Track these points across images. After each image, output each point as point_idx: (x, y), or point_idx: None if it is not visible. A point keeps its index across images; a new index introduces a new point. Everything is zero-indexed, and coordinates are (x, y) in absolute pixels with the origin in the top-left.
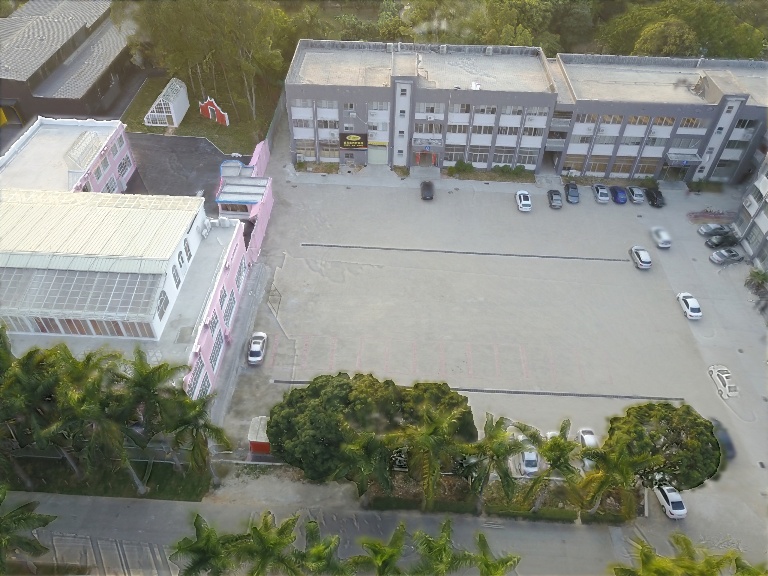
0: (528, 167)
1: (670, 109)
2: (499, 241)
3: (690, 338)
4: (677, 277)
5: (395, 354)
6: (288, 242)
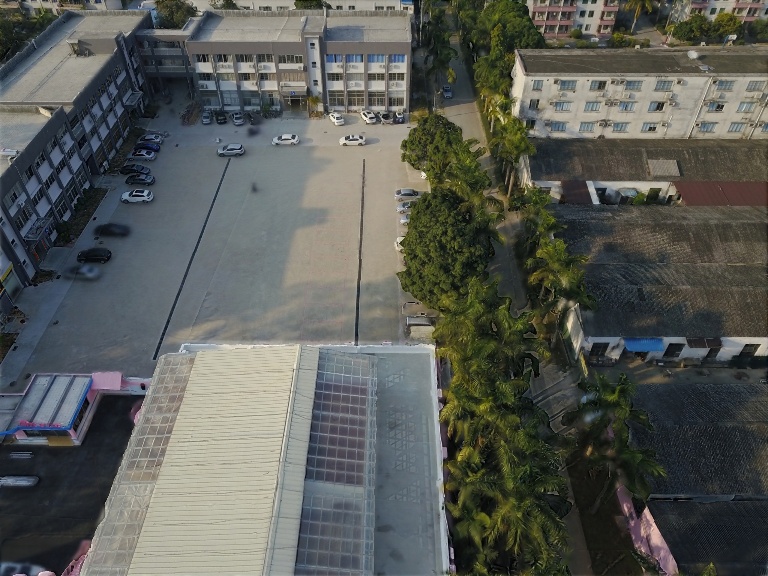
0: (86, 187)
1: (106, 69)
2: (188, 219)
3: (313, 147)
4: (254, 142)
5: (325, 283)
6: (147, 372)
